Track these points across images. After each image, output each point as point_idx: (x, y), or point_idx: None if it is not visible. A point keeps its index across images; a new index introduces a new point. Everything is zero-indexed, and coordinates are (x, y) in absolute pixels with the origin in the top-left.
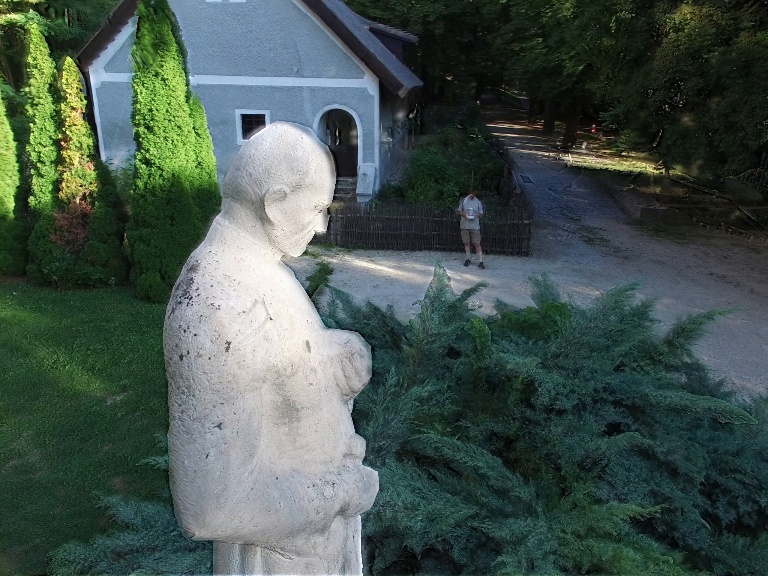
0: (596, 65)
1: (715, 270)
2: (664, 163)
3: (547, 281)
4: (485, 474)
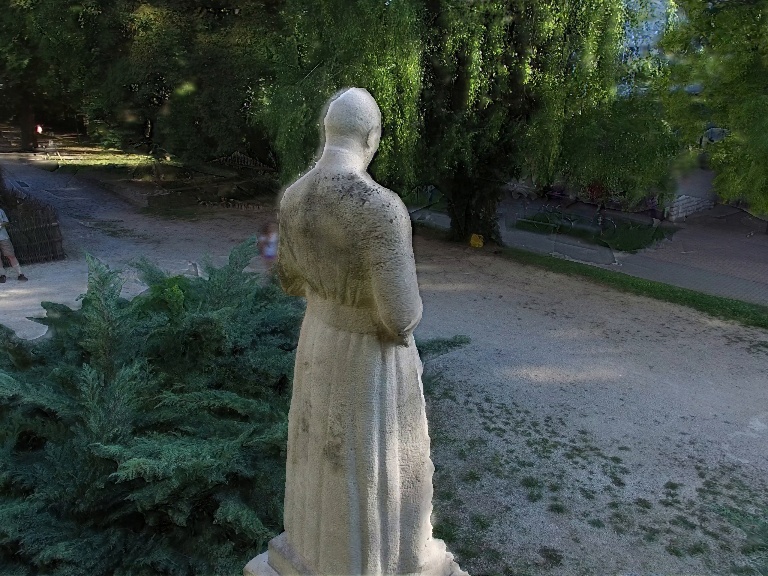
0: (63, 60)
1: (234, 237)
2: (154, 153)
3: (148, 263)
4: (233, 407)
